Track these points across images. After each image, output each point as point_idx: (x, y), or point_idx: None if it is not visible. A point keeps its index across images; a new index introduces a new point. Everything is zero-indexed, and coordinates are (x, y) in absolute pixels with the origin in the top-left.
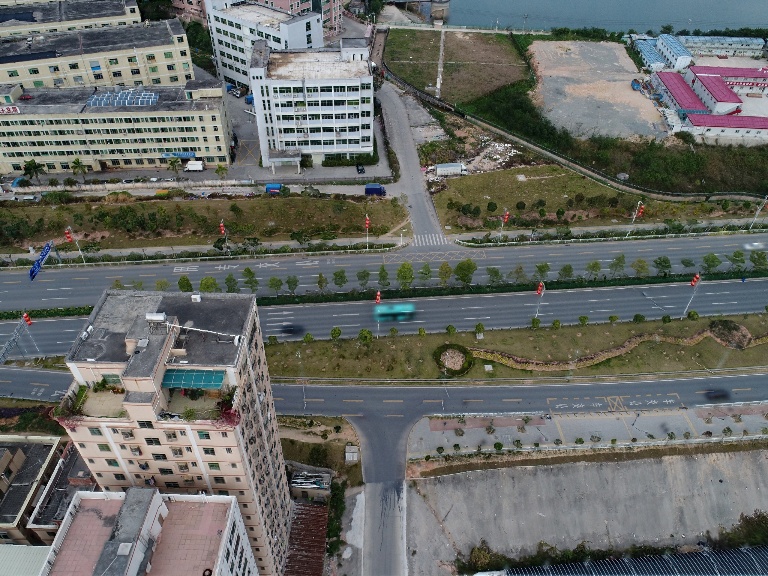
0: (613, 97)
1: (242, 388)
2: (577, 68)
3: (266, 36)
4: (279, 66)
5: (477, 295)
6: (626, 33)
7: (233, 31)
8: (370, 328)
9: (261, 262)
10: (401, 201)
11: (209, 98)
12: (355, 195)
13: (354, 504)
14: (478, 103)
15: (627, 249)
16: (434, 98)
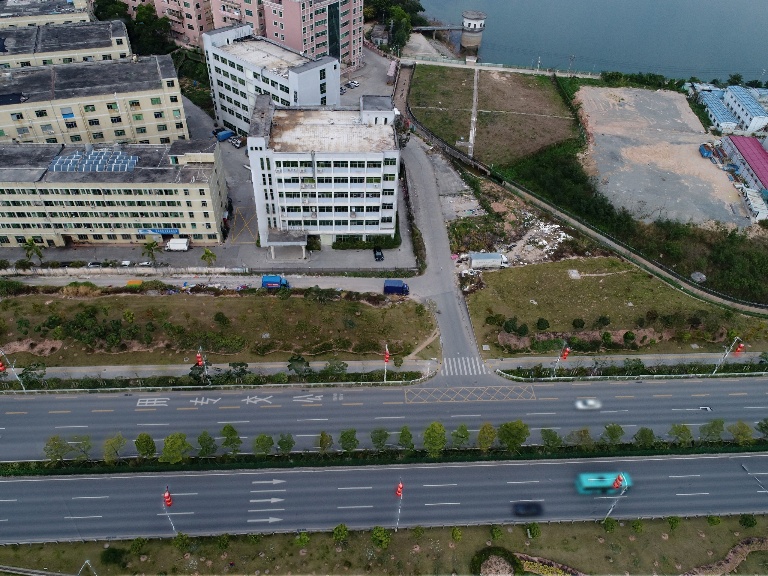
0: (679, 166)
1: None
2: (633, 125)
3: (272, 83)
4: (285, 130)
5: (526, 461)
6: (687, 81)
7: (234, 73)
8: (386, 513)
9: (249, 395)
10: None
11: (198, 164)
12: (371, 293)
13: None
14: (519, 167)
15: (715, 392)
16: (466, 156)
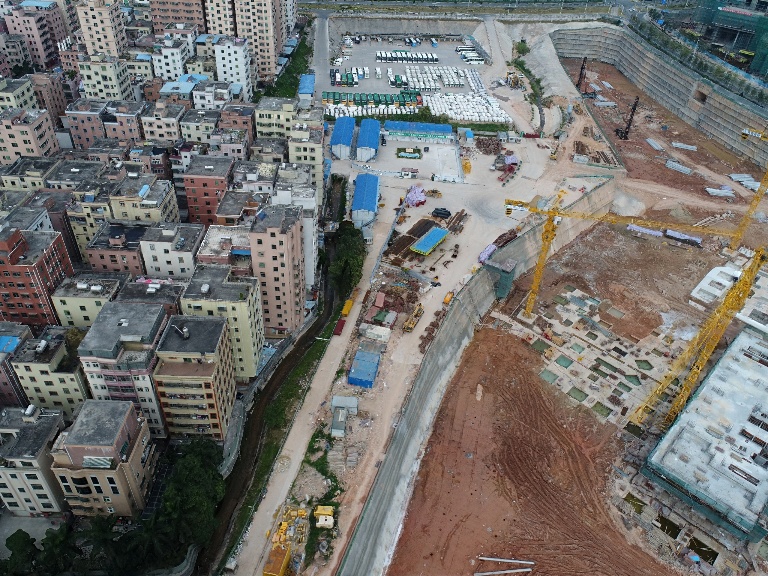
0: None
1: None
2: None
3: None
4: None
5: None
6: None
7: None
8: None
9: None
10: None
11: None
12: None
13: (314, 20)
14: None
15: None
16: None
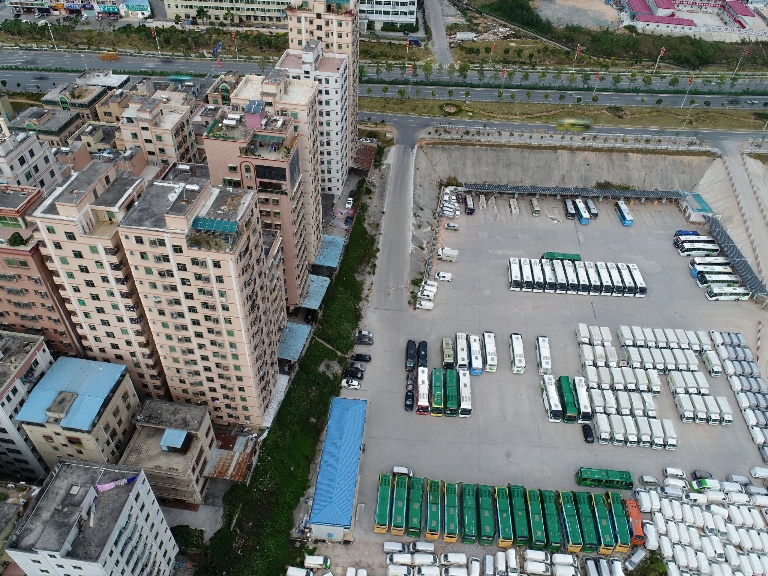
0: (589, 7)
1: (354, 11)
2: None
3: None
4: None
5: (470, 88)
6: None
7: None
8: None
9: None
10: (431, 50)
11: None
12: None
13: (389, 151)
14: (492, 6)
15: None
16: (462, 3)
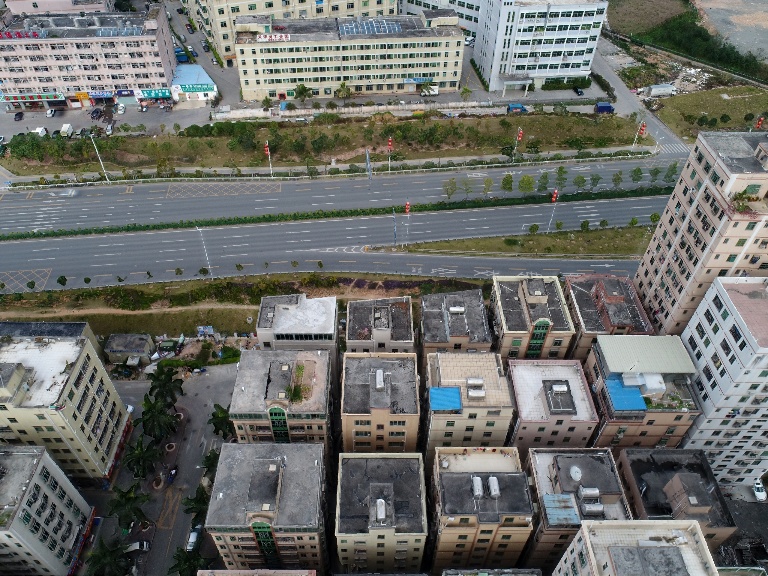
0: None
1: None
2: (731, 1)
3: None
4: None
5: None
6: None
7: None
8: None
9: (540, 168)
10: None
11: (445, 26)
12: (588, 113)
13: None
14: (654, 33)
15: None
16: (607, 30)
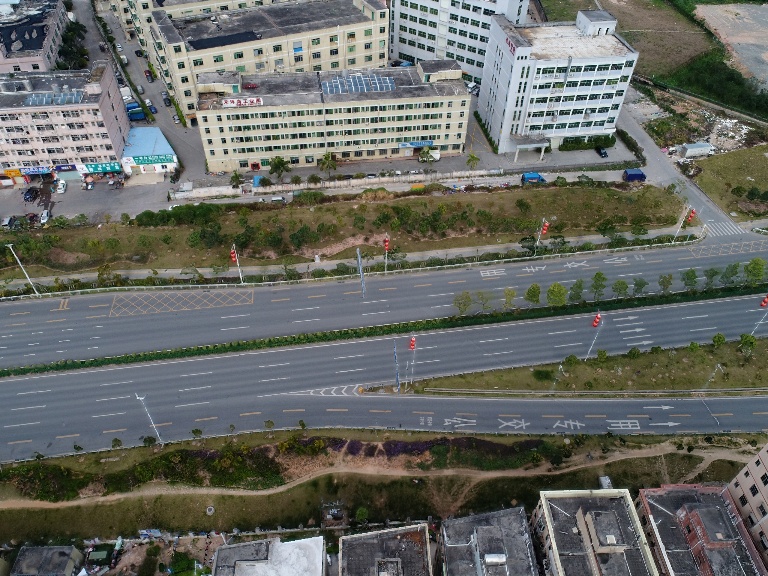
0: None
1: None
2: (760, 34)
3: (474, 9)
4: None
5: None
6: None
7: (426, 4)
8: (730, 331)
9: (567, 261)
10: None
11: (446, 81)
12: (615, 182)
13: None
14: (679, 75)
15: None
16: None
